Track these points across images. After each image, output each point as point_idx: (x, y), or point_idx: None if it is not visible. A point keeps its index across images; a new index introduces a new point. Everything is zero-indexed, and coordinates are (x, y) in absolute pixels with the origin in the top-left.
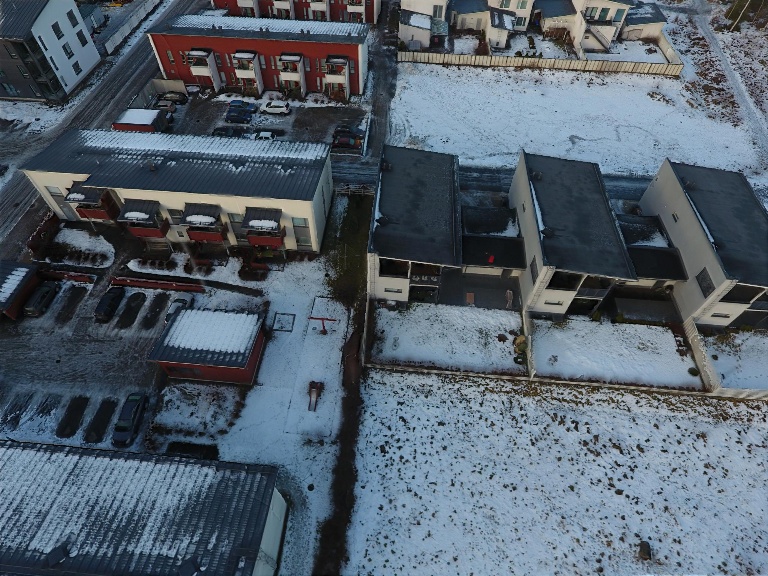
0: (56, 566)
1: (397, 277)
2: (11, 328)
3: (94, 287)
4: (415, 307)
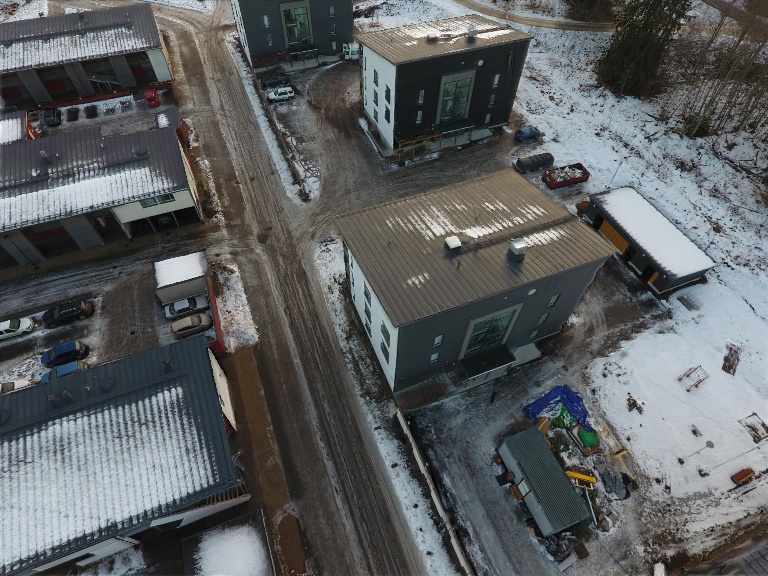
0: None
1: None
2: None
3: None
4: None
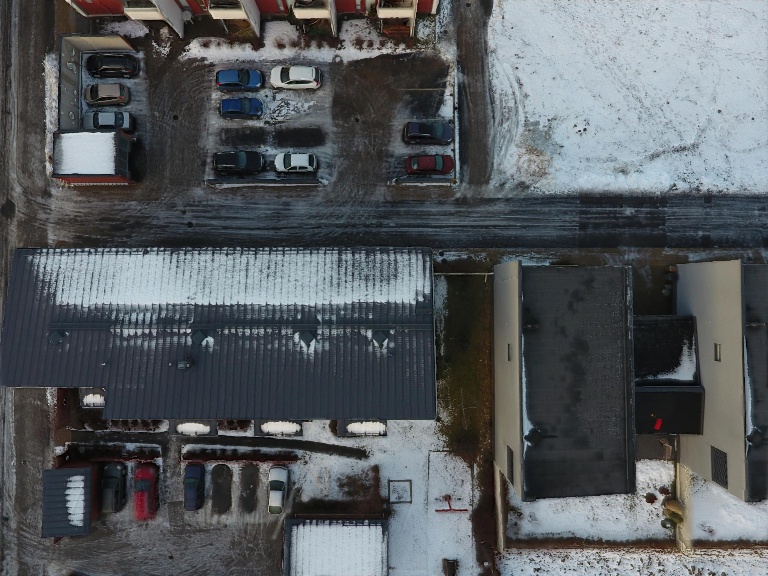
0: None
1: None
2: (99, 525)
3: (164, 461)
4: None
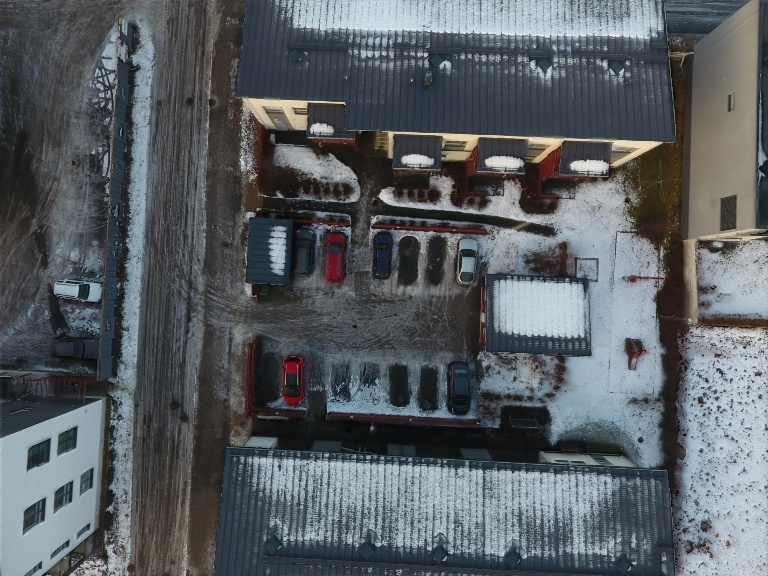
0: (517, 567)
1: (758, 235)
2: (286, 291)
3: (353, 231)
4: (742, 246)
